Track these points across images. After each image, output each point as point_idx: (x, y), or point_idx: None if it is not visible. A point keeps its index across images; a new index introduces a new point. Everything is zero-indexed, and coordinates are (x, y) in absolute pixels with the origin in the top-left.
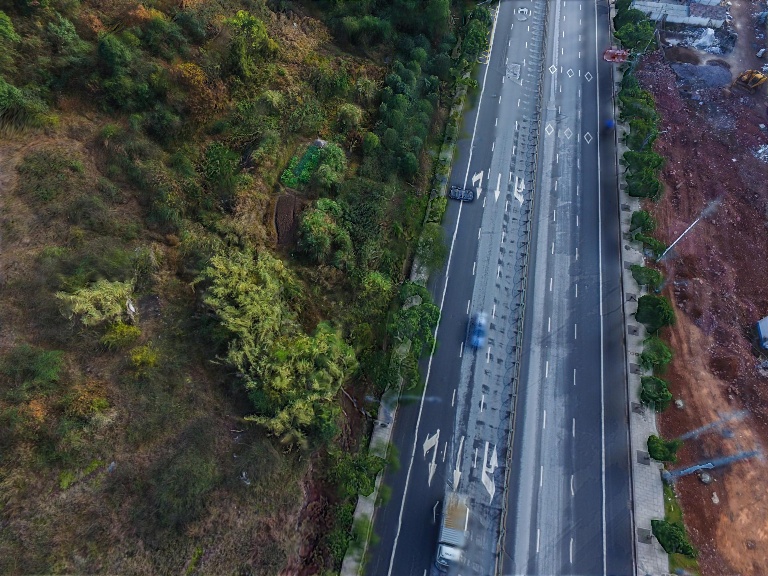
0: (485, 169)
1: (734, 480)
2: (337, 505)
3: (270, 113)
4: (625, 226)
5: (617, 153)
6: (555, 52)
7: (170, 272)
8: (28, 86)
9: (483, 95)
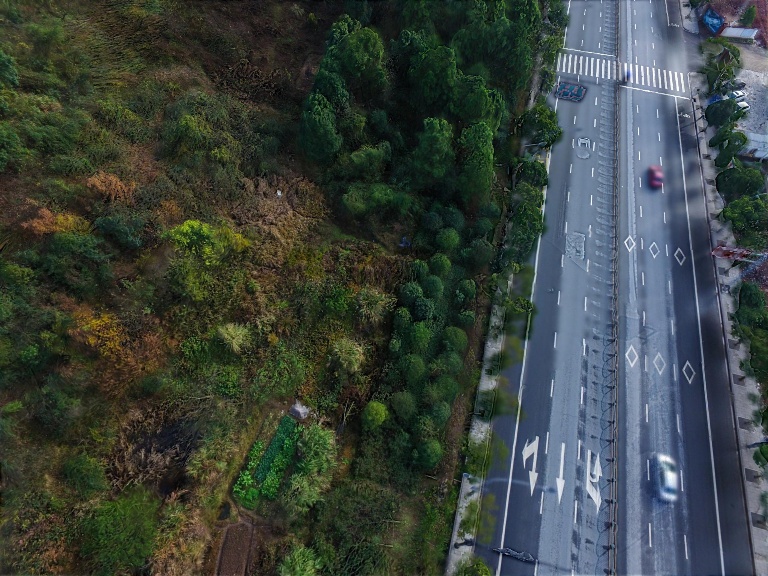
0: (541, 433)
1: None
2: None
3: (229, 360)
4: (762, 563)
5: (734, 405)
6: (631, 213)
7: None
8: None
9: (535, 289)
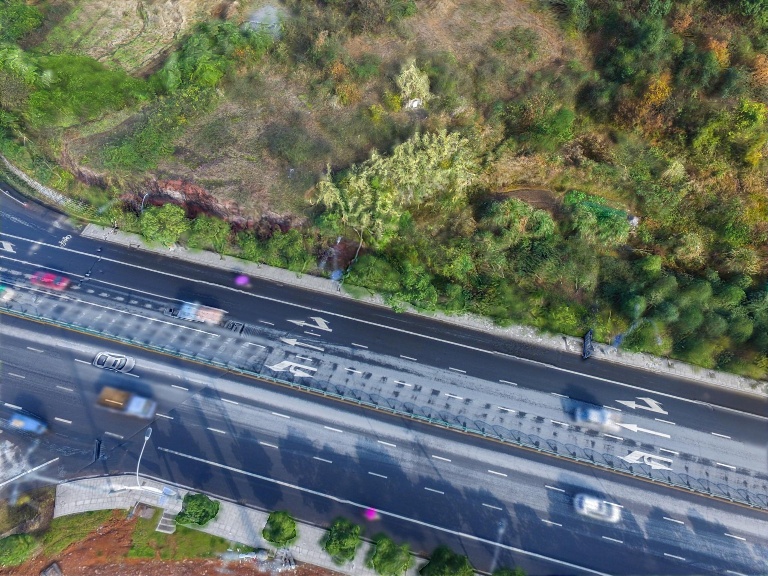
0: (672, 417)
1: None
2: None
3: (655, 173)
4: None
5: None
6: None
7: (450, 122)
8: (593, 8)
9: None
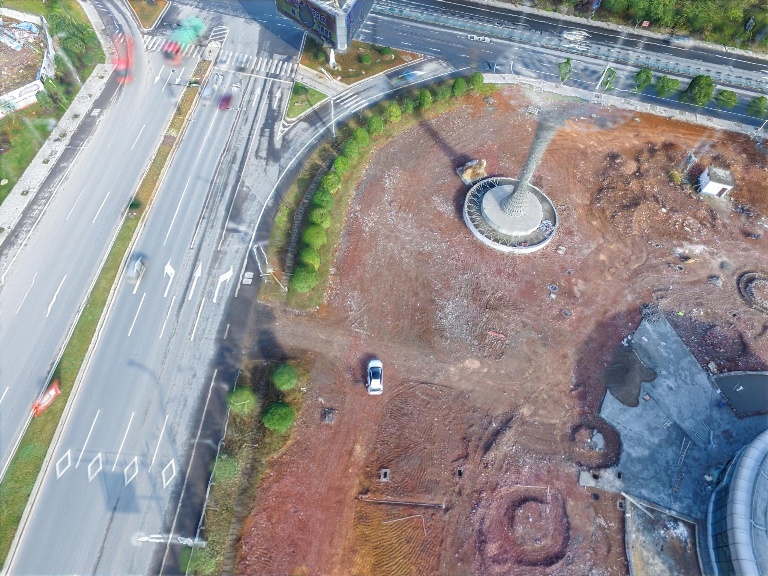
0: None
1: (596, 129)
2: (552, 2)
3: None
4: None
5: None
6: None
7: None
8: None
9: None
